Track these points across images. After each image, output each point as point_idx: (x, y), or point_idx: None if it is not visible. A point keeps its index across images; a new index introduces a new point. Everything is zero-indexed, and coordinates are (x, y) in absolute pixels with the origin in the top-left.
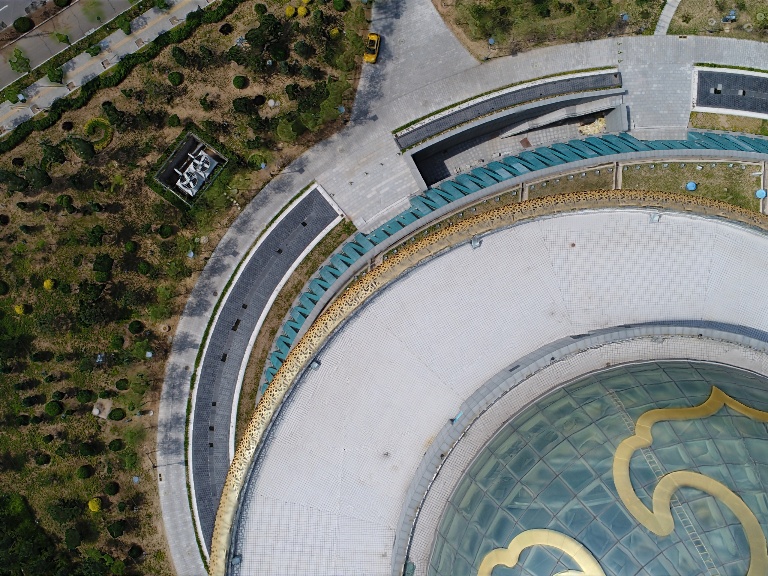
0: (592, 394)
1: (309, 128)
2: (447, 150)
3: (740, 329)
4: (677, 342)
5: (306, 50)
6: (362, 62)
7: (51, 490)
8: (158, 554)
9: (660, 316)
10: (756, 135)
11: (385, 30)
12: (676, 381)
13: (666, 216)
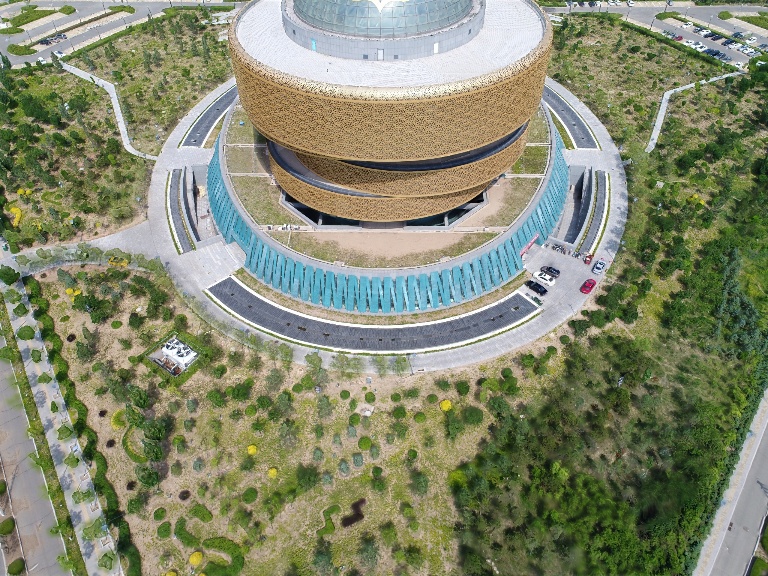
0: (302, 7)
1: (165, 273)
2: None
3: None
4: (288, 3)
5: None
6: None
7: (439, 447)
8: (482, 369)
9: None
10: None
11: None
12: None
13: None
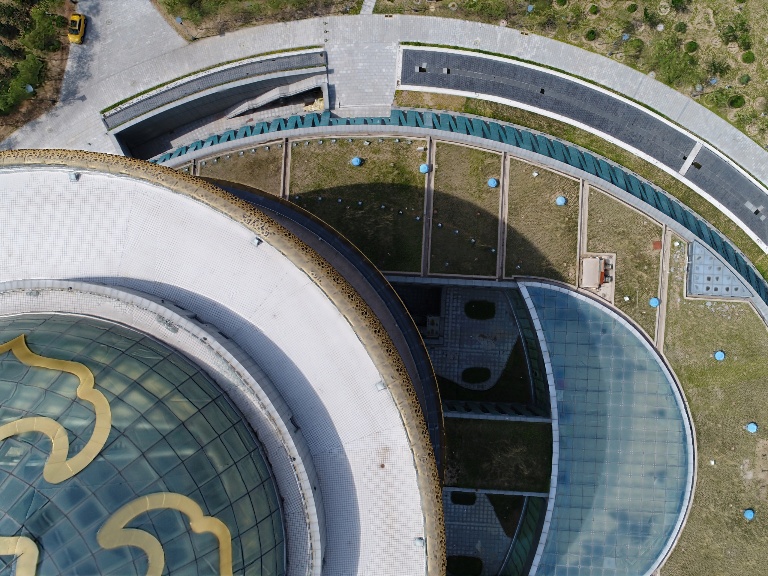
0: None
1: None
2: (173, 131)
3: (156, 285)
4: (50, 295)
5: (6, 31)
6: (69, 43)
7: None
8: None
9: (78, 273)
10: (459, 113)
11: (91, 11)
12: (1, 330)
13: (85, 175)
